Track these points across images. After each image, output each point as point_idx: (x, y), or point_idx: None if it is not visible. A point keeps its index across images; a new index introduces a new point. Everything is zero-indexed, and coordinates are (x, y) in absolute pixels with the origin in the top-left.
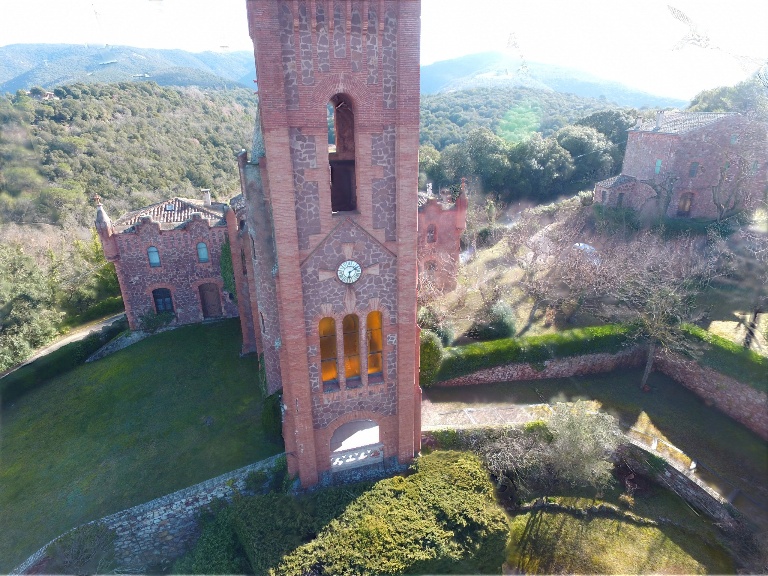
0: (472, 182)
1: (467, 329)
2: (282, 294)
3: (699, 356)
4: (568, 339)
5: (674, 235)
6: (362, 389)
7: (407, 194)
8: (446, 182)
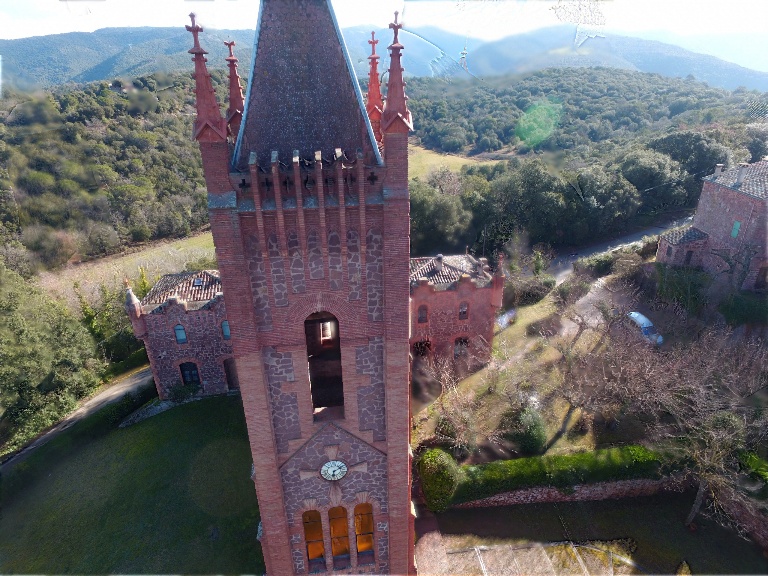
0: (522, 219)
1: (493, 429)
2: (260, 497)
3: (760, 499)
4: (602, 464)
5: (743, 341)
6: (351, 569)
7: (396, 402)
8: (494, 218)
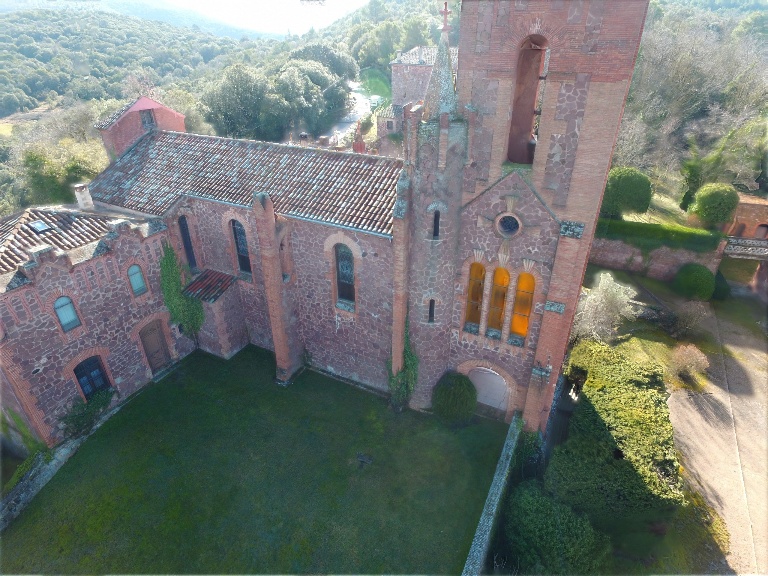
0: (251, 128)
1: None
2: None
3: None
4: None
5: None
6: None
7: None
8: None
